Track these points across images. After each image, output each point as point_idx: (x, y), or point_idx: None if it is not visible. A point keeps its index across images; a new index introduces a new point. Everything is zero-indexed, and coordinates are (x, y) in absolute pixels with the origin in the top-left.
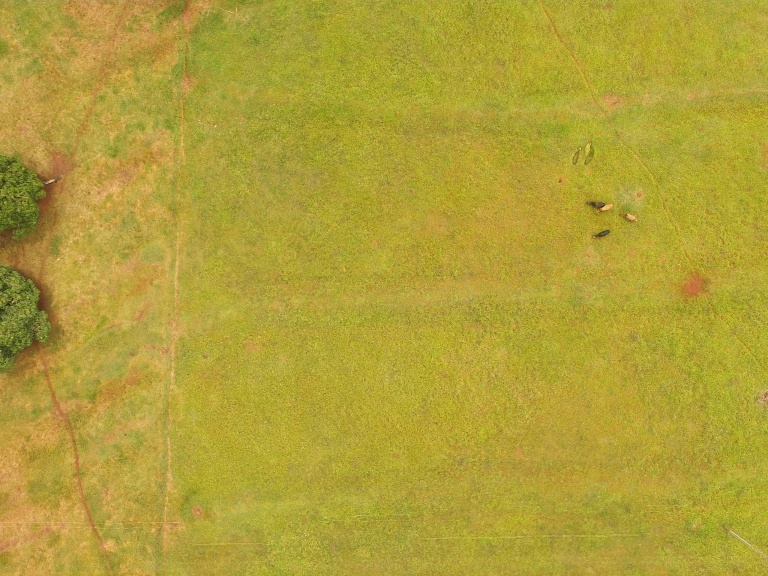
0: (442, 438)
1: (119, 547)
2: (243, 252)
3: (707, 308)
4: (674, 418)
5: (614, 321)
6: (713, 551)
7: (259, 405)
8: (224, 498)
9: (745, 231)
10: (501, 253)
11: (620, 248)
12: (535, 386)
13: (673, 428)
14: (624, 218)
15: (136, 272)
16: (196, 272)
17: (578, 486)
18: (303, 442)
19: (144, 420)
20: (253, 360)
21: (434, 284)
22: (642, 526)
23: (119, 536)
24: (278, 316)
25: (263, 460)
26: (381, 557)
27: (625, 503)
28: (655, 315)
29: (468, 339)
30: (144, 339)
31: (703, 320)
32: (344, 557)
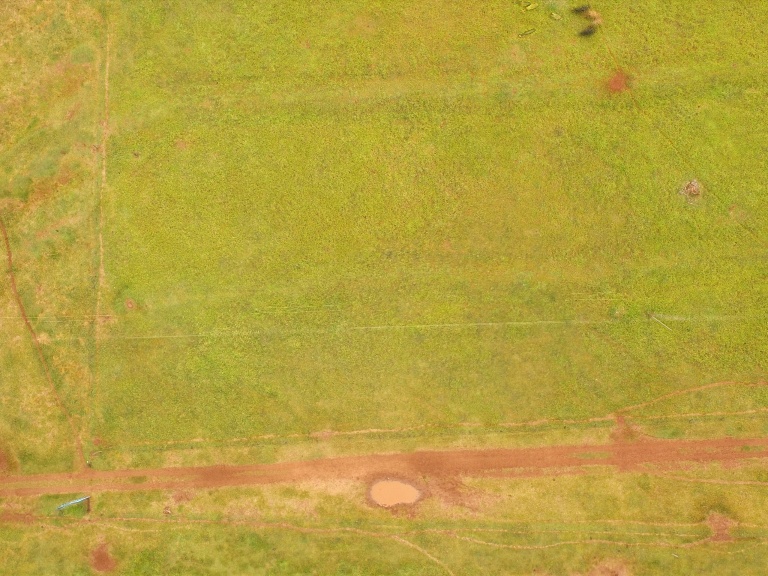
0: (371, 231)
1: (52, 340)
2: (173, 53)
3: (630, 104)
4: (598, 209)
5: (539, 117)
6: (635, 336)
7: (190, 201)
8: (156, 291)
9: (668, 29)
10: (428, 52)
11: (545, 46)
12: (462, 180)
13: (597, 219)
14: (549, 17)
15: (67, 73)
16: (126, 73)
17: (504, 275)
18: (234, 236)
19: (76, 217)
20: (184, 158)
21: (362, 83)
22: (566, 313)
23: (52, 329)
24: (208, 115)
25: (194, 254)
26: (311, 347)
27: (550, 291)
28: (580, 111)
29: (396, 135)
30: (75, 137)
31: (627, 115)
32: (275, 347)
